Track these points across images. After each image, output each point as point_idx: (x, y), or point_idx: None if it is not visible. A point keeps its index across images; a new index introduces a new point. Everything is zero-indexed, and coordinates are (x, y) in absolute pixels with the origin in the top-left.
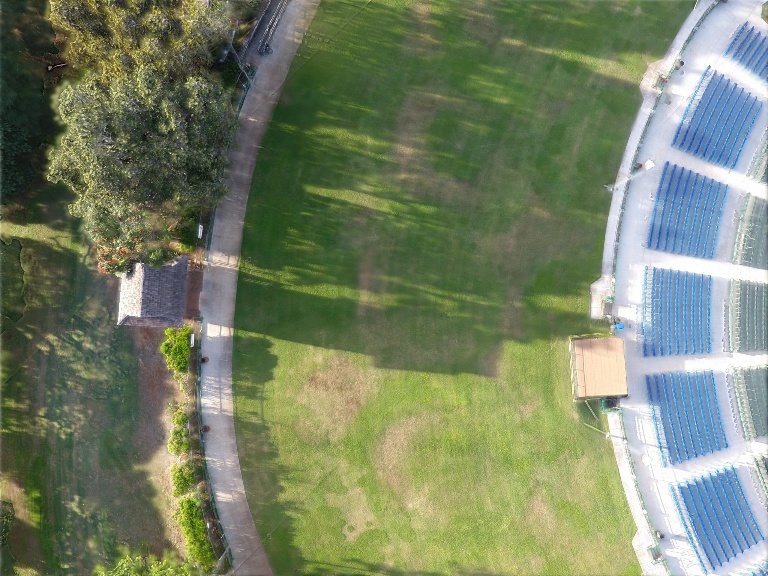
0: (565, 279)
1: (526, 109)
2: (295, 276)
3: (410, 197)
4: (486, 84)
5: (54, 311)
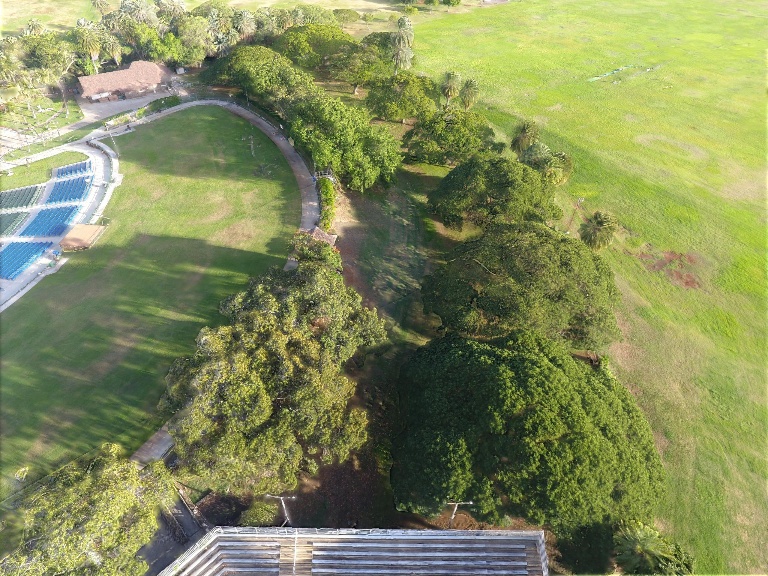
0: (70, 275)
1: (13, 367)
2: (241, 280)
3: (142, 317)
4: (31, 385)
5: (419, 301)
